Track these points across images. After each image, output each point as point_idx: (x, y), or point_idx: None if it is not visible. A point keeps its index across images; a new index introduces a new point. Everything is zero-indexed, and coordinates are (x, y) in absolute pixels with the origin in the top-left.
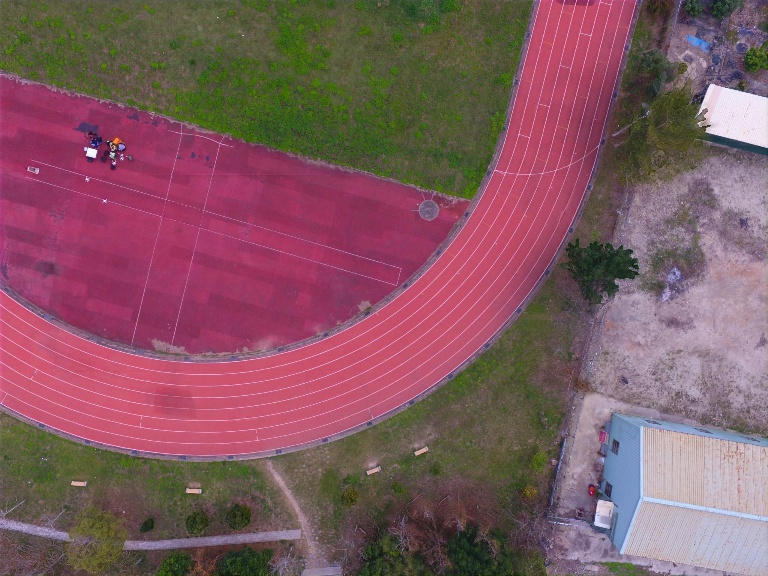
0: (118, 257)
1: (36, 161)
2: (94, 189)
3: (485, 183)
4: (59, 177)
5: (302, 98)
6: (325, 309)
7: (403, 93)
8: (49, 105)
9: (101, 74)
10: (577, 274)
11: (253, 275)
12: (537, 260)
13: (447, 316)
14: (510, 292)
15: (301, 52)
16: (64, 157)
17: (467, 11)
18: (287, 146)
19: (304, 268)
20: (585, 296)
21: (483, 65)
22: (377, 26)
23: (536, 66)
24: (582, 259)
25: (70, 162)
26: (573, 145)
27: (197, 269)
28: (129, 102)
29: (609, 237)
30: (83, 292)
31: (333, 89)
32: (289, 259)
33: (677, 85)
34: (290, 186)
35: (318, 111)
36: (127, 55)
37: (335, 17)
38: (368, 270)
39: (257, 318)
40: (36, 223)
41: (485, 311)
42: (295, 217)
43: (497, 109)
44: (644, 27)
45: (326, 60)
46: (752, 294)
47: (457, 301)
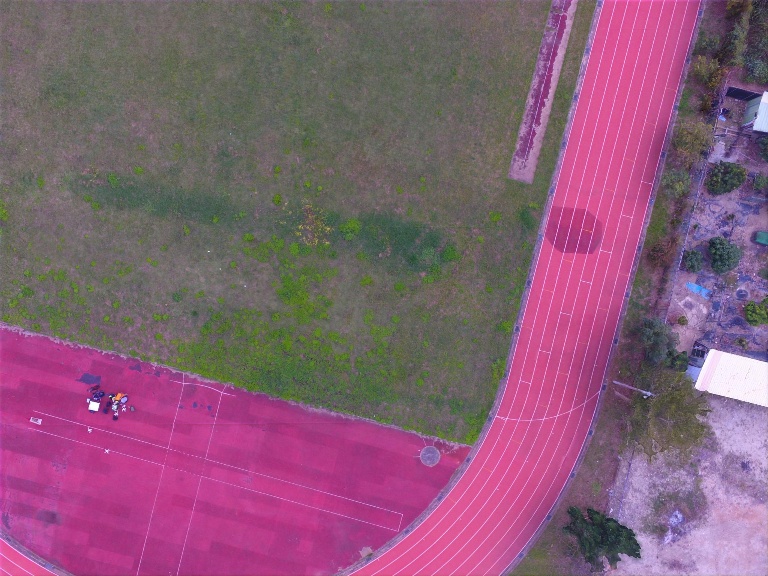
0: (120, 506)
1: (39, 412)
2: (96, 439)
3: (486, 429)
4: (61, 427)
5: (304, 347)
6: (326, 556)
7: (404, 341)
8: (52, 357)
9: (104, 326)
10: (579, 544)
11: (254, 522)
12: (539, 505)
13: (449, 562)
14: (512, 537)
15: (303, 302)
16: (66, 408)
17: (468, 260)
18: (289, 395)
19: (305, 515)
20: (587, 560)
21: (484, 313)
22: (378, 276)
23: (537, 313)
24: (584, 536)
25: (72, 413)
26: (574, 391)
27: (198, 517)
28: (131, 354)
29: (611, 482)
30: (84, 541)
31: (335, 338)
32: (290, 506)
33: (677, 331)
34: (292, 434)
35: (320, 360)
36: (130, 307)
37: (337, 267)
38: (369, 516)
39: (258, 565)
40: (38, 473)
41: (487, 556)
42: (297, 465)
43: (498, 356)
44: (644, 275)
45: (328, 309)
46: (754, 536)
47: (459, 547)
